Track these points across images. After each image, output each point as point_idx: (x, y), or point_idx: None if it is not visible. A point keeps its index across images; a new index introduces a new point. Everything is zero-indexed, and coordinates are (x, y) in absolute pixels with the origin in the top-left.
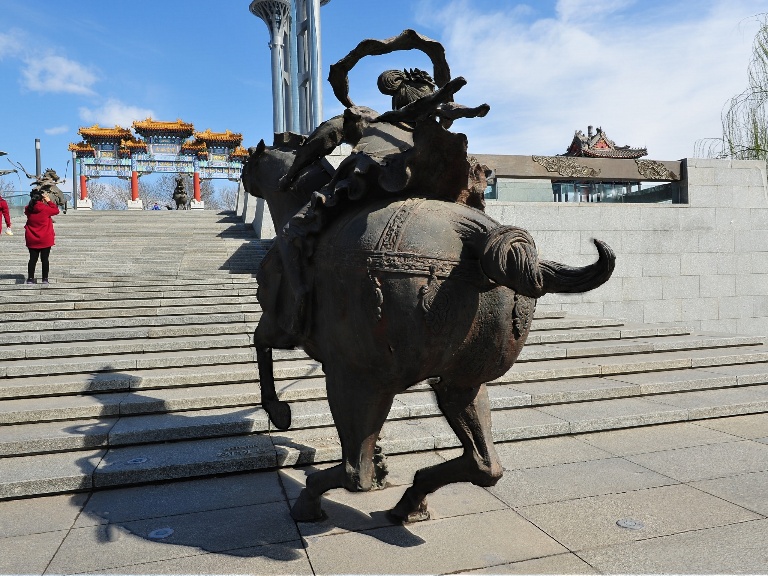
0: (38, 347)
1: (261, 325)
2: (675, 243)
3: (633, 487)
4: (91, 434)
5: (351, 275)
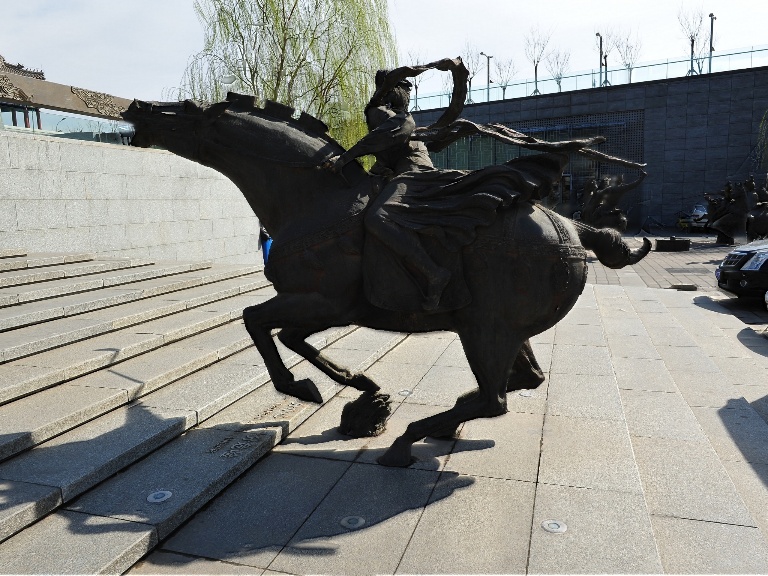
0: None
1: (306, 307)
2: (195, 190)
3: None
4: (41, 498)
5: (541, 261)
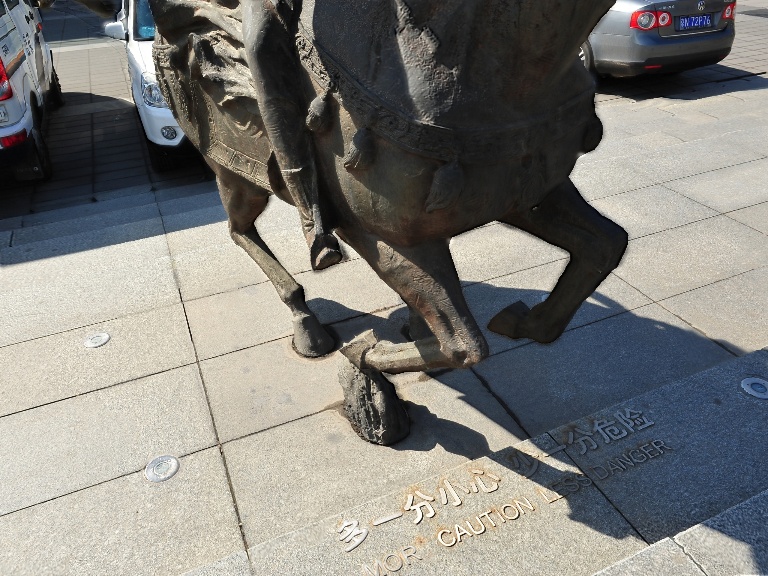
0: None
1: None
2: None
3: (6, 420)
4: None
5: None
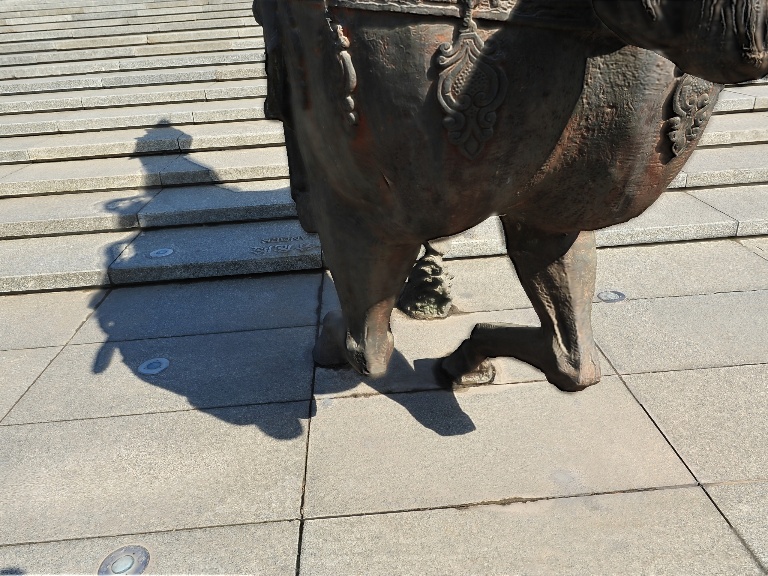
0: (95, 94)
1: None
2: None
3: None
4: (118, 214)
5: (304, 17)
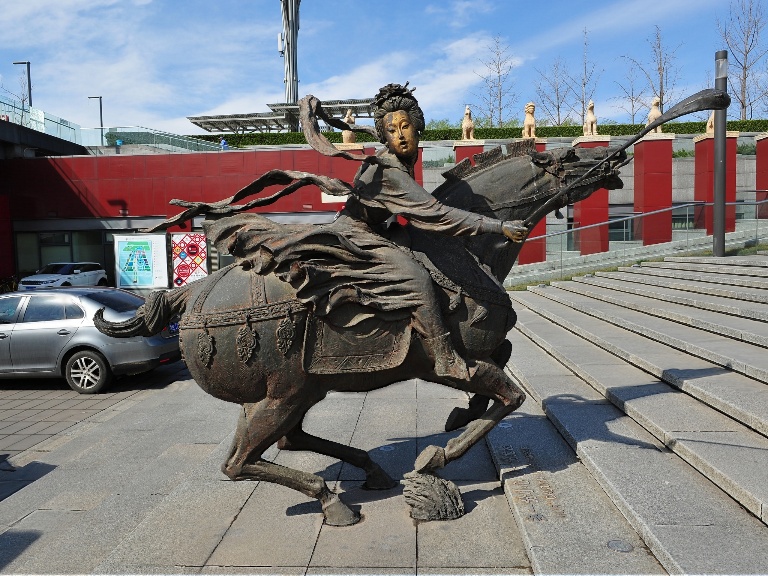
0: None
1: None
2: None
3: None
4: None
5: None
